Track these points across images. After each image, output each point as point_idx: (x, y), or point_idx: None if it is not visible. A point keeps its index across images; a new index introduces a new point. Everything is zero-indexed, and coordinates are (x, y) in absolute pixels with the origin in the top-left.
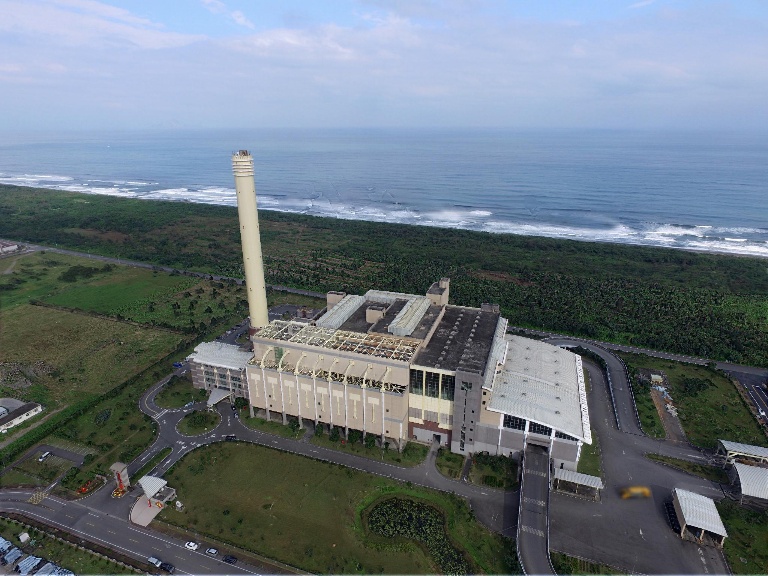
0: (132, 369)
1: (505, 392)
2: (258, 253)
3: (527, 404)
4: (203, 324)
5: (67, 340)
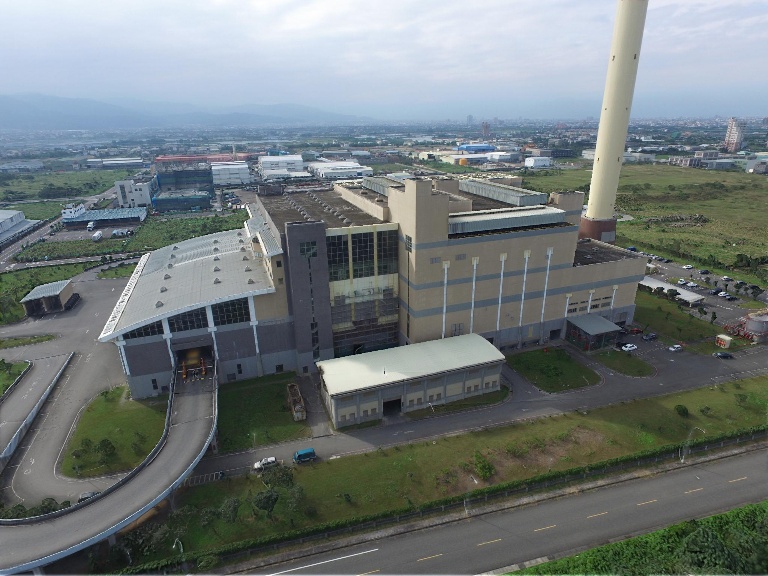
0: (644, 240)
1: (239, 237)
2: (605, 102)
3: (212, 239)
4: (755, 262)
5: (764, 234)
